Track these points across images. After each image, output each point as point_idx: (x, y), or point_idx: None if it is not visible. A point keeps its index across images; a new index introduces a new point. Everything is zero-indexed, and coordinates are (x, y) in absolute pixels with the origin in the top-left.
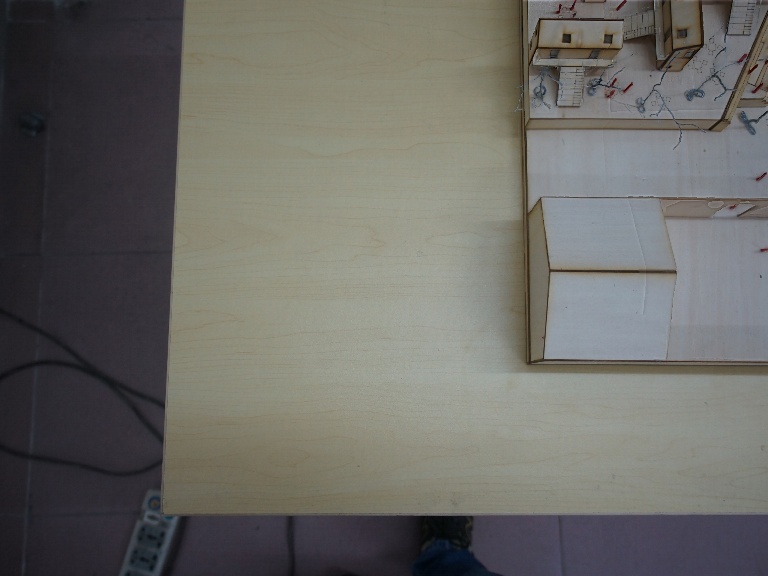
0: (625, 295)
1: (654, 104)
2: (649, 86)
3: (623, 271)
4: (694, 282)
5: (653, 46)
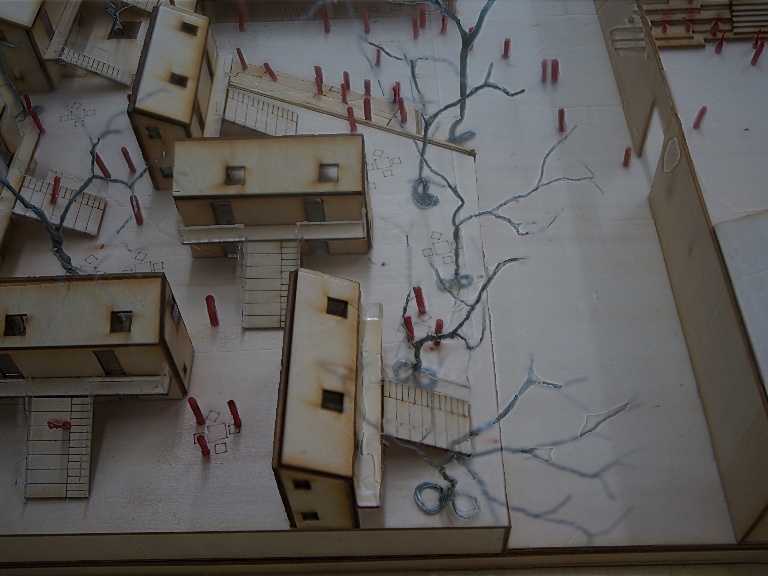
0: None
1: (449, 260)
2: (407, 268)
3: None
4: None
5: (314, 258)
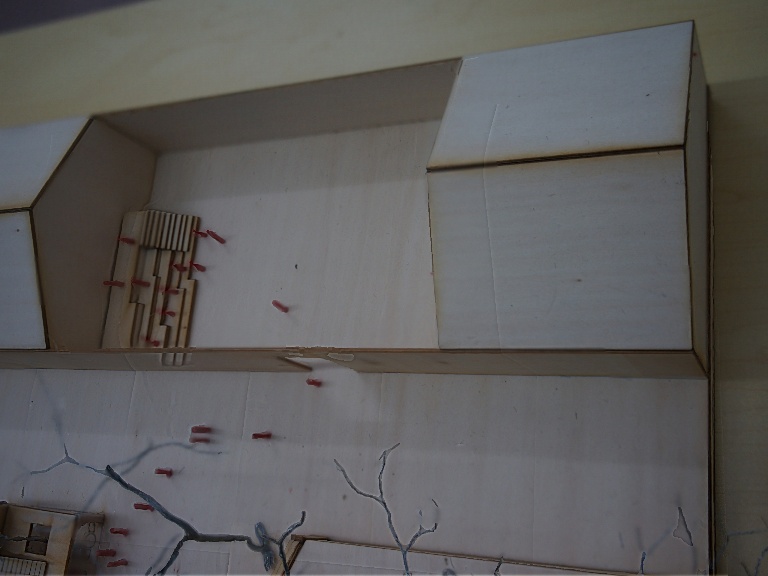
0: (528, 126)
1: None
2: None
3: (528, 162)
4: (399, 250)
5: None
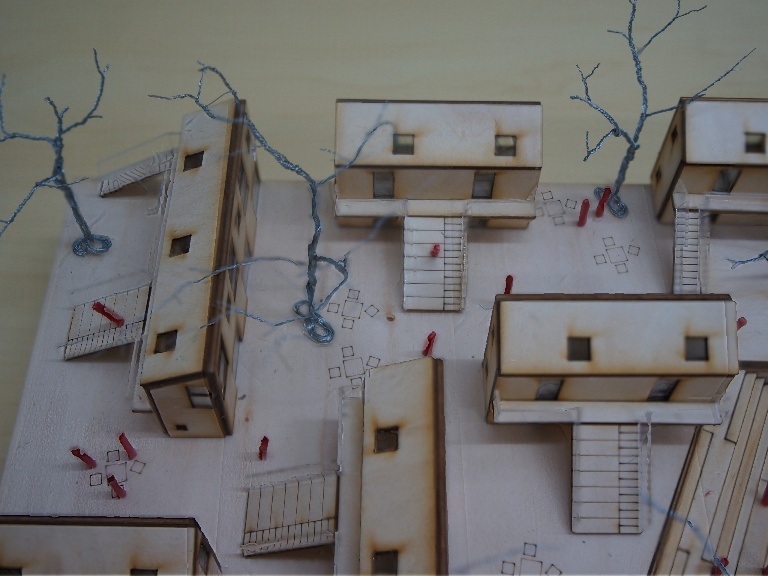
0: None
1: None
2: None
3: None
4: None
5: None
